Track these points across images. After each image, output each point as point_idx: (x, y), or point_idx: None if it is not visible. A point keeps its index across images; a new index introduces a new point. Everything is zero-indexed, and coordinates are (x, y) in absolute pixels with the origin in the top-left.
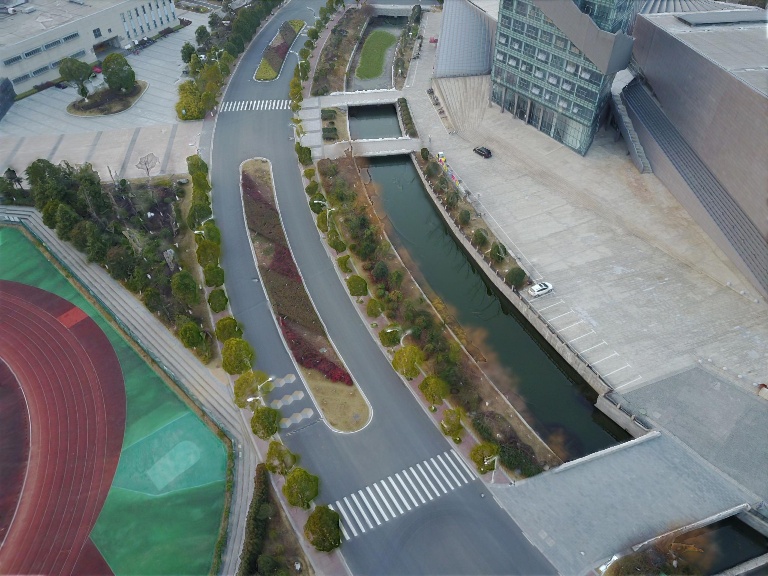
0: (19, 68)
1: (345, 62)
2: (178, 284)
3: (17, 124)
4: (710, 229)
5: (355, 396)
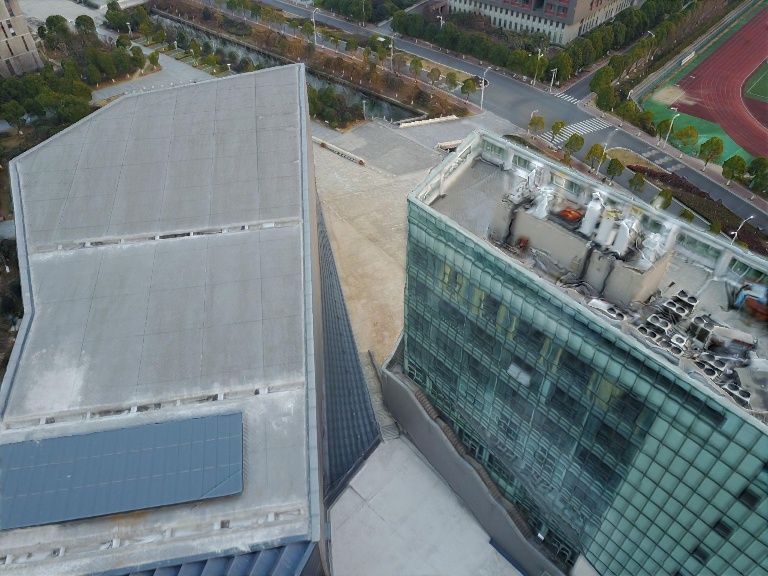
0: None
1: None
2: None
3: None
4: None
5: (621, 161)
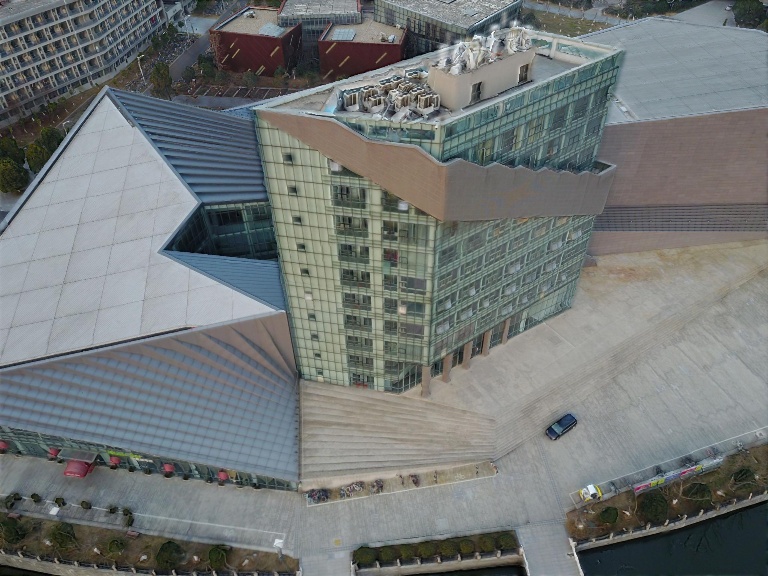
0: None
1: None
2: None
3: None
4: (706, 240)
5: None
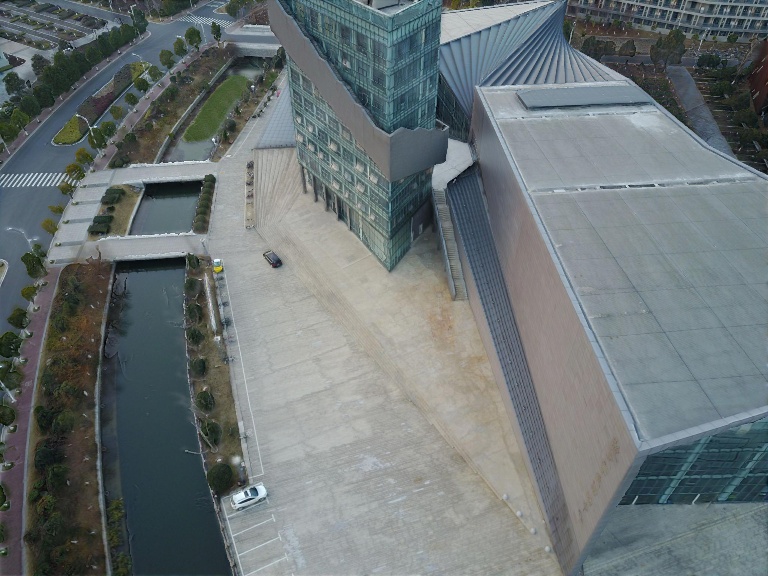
0: None
1: (175, 119)
2: None
3: None
4: (506, 401)
5: None
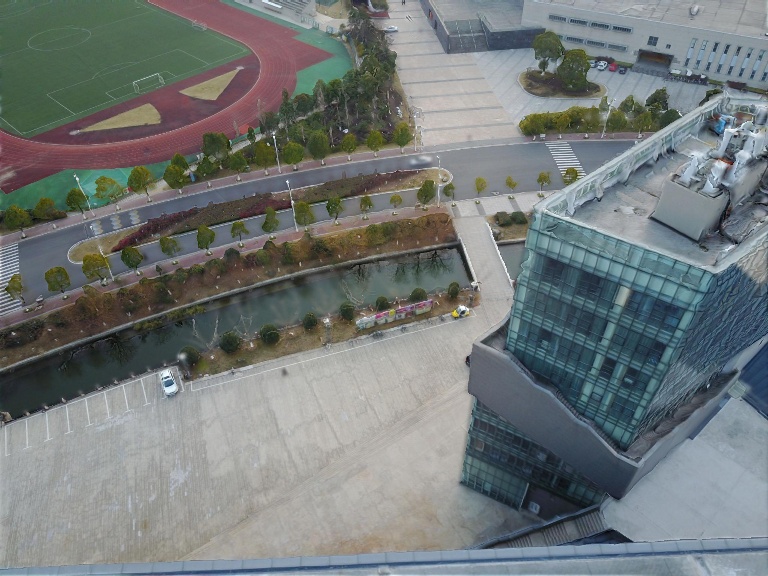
0: (560, 27)
1: None
2: (204, 135)
3: (496, 57)
4: None
5: None
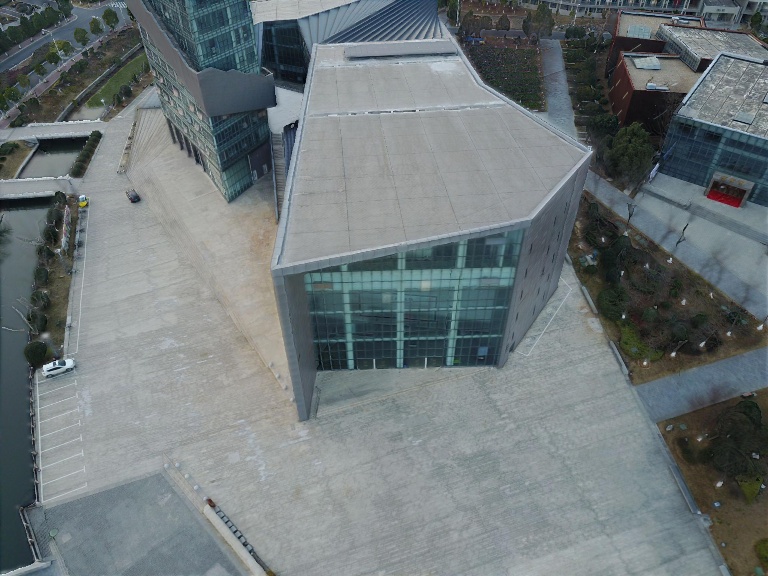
0: None
1: (81, 88)
2: None
3: None
4: None
5: None
